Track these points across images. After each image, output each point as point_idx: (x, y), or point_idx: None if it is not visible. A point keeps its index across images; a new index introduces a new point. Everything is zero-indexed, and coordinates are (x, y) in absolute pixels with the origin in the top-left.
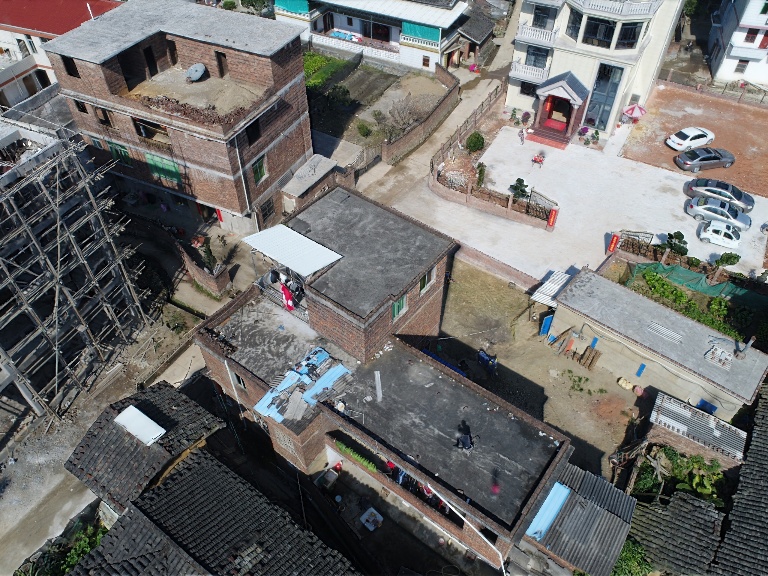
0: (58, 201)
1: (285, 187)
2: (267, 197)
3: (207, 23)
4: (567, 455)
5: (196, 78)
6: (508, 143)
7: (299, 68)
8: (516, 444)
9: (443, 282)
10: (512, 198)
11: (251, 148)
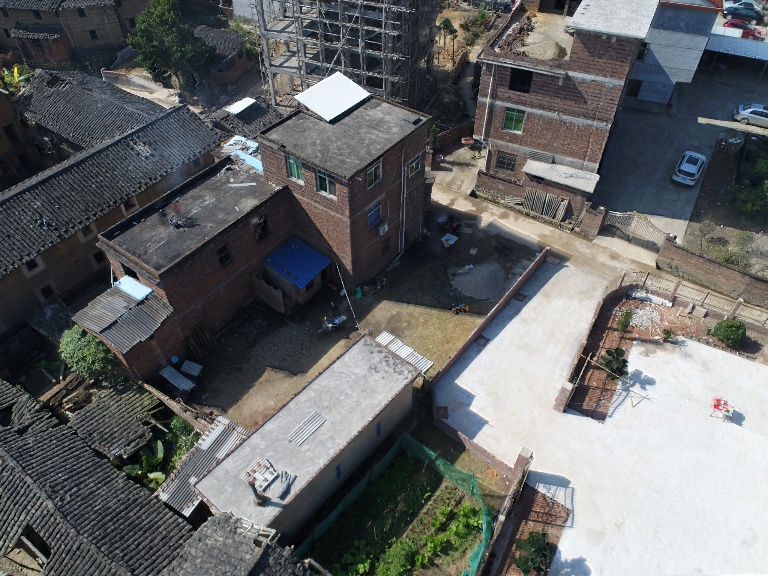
0: (365, 2)
1: (533, 161)
2: (511, 150)
3: None
4: (151, 278)
5: (567, 29)
6: (765, 382)
7: (618, 73)
8: (170, 250)
9: (349, 216)
10: (582, 344)
11: (511, 92)
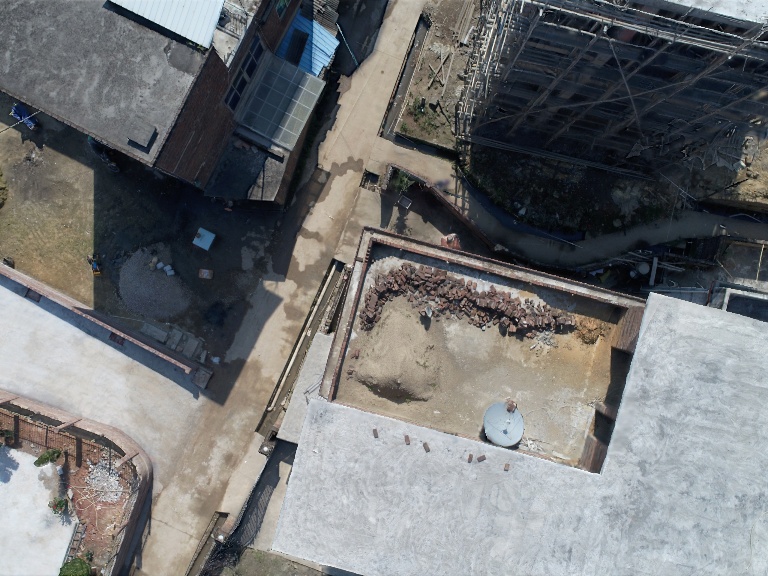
0: None
1: None
2: None
3: (507, 526)
4: None
5: (495, 406)
6: None
7: None
8: None
9: None
10: None
11: None
